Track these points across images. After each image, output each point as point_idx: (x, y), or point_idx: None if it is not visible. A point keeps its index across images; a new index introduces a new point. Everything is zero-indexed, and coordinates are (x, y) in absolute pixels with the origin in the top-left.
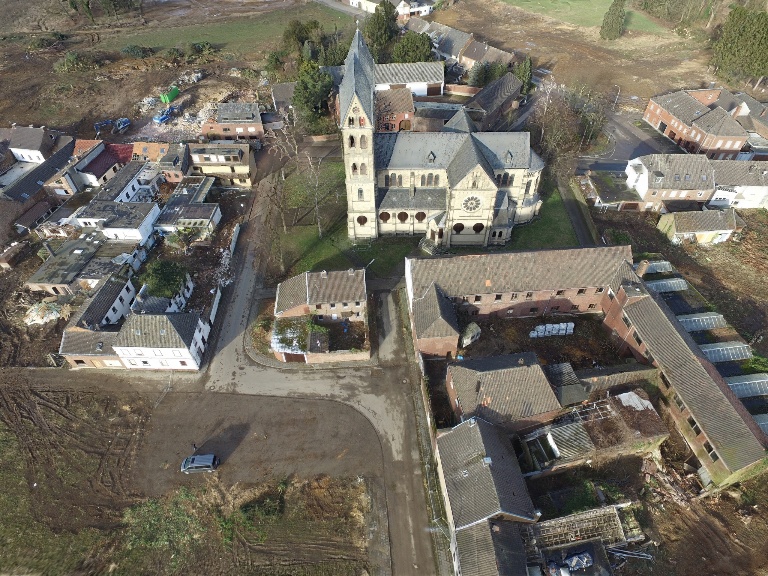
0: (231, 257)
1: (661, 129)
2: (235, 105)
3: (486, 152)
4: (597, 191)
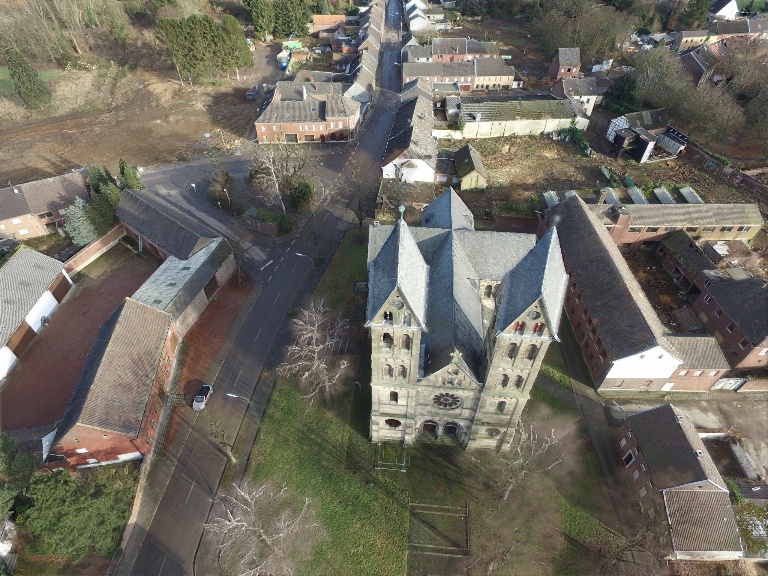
0: None
1: (290, 140)
2: None
3: None
4: None
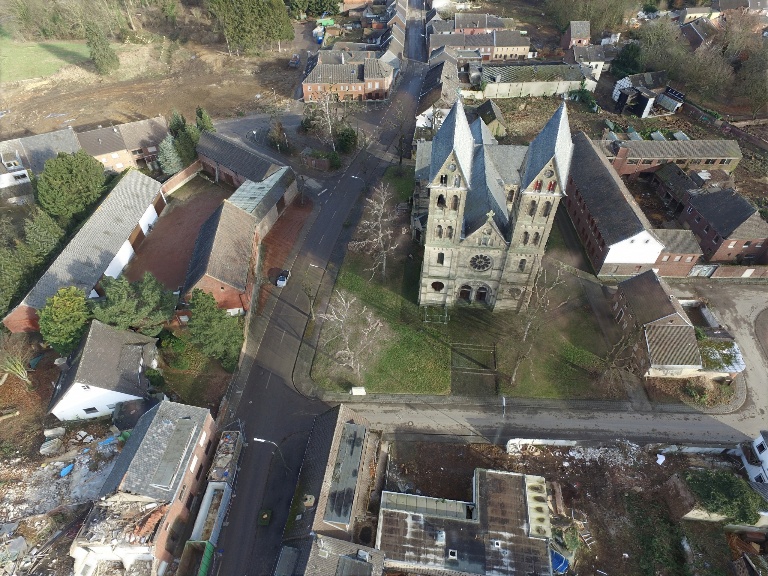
0: (581, 447)
1: None
2: (145, 448)
3: None
4: None
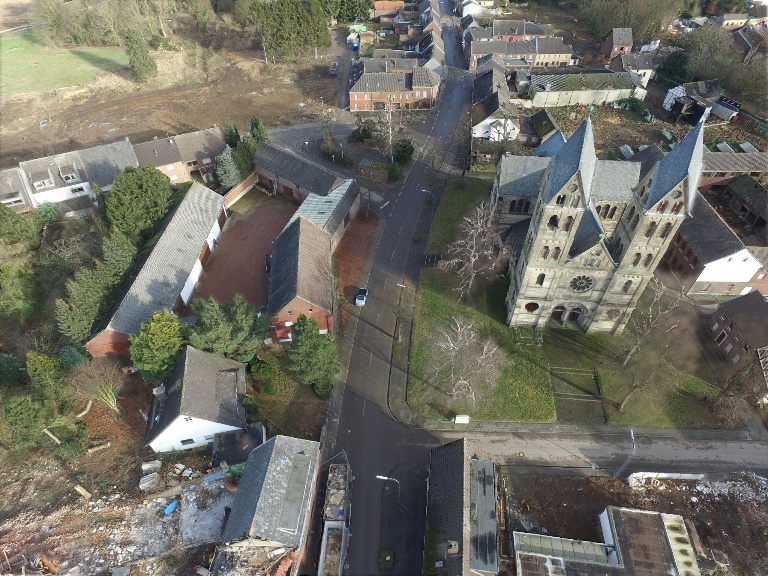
0: (706, 481)
1: (378, 108)
2: (268, 488)
3: None
4: None
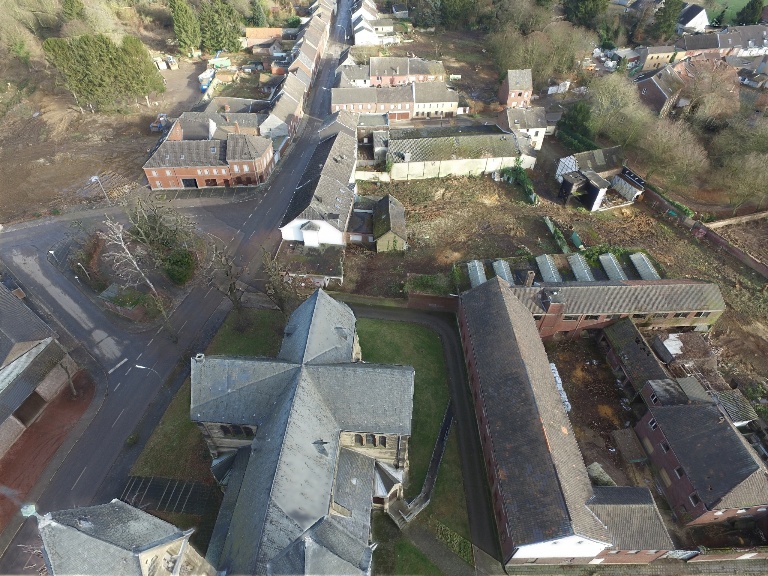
0: None
1: (189, 185)
2: None
3: (330, 358)
4: (317, 274)
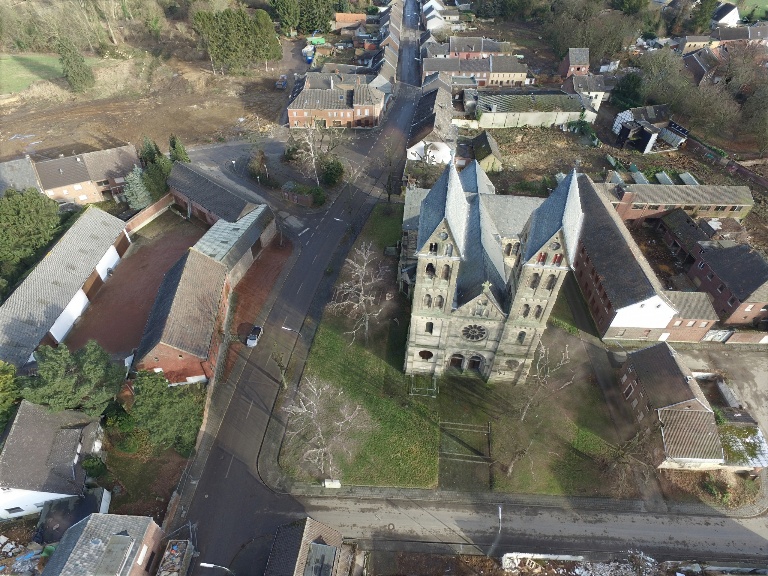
0: (588, 562)
1: None
2: None
3: None
4: None
